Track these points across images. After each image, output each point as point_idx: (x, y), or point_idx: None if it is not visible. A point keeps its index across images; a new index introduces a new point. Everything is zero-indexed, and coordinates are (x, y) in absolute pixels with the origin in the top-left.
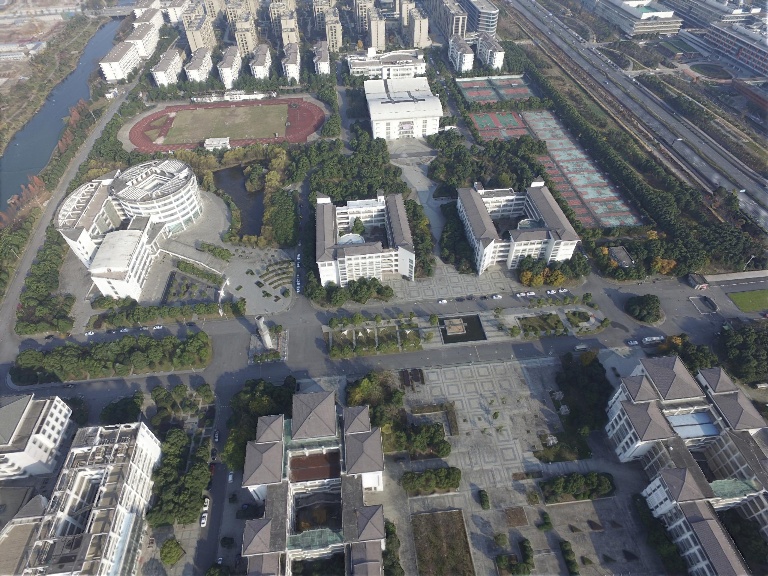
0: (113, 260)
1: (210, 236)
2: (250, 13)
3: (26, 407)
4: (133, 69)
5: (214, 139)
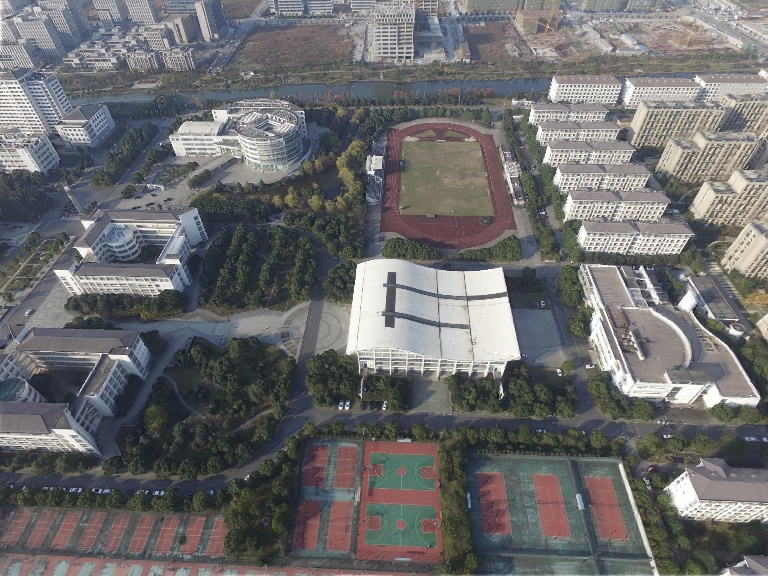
0: (186, 127)
1: (232, 178)
2: (755, 140)
3: (80, 120)
4: (580, 102)
5: (380, 160)
